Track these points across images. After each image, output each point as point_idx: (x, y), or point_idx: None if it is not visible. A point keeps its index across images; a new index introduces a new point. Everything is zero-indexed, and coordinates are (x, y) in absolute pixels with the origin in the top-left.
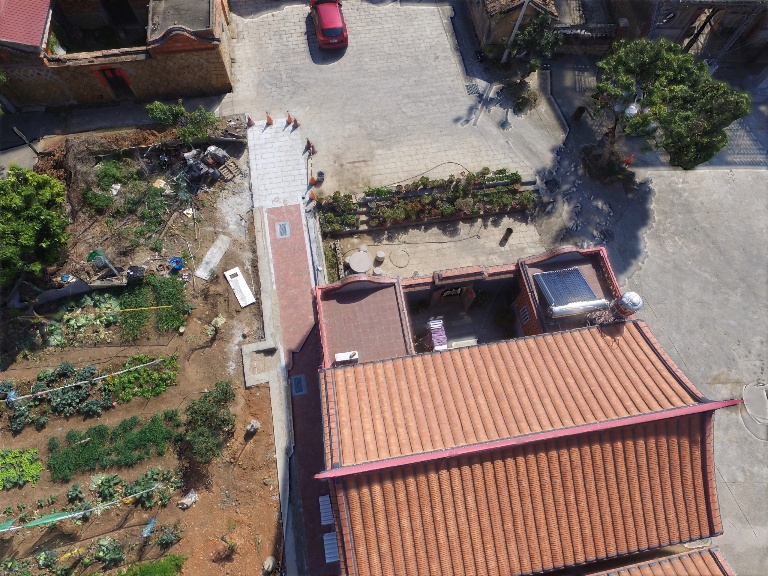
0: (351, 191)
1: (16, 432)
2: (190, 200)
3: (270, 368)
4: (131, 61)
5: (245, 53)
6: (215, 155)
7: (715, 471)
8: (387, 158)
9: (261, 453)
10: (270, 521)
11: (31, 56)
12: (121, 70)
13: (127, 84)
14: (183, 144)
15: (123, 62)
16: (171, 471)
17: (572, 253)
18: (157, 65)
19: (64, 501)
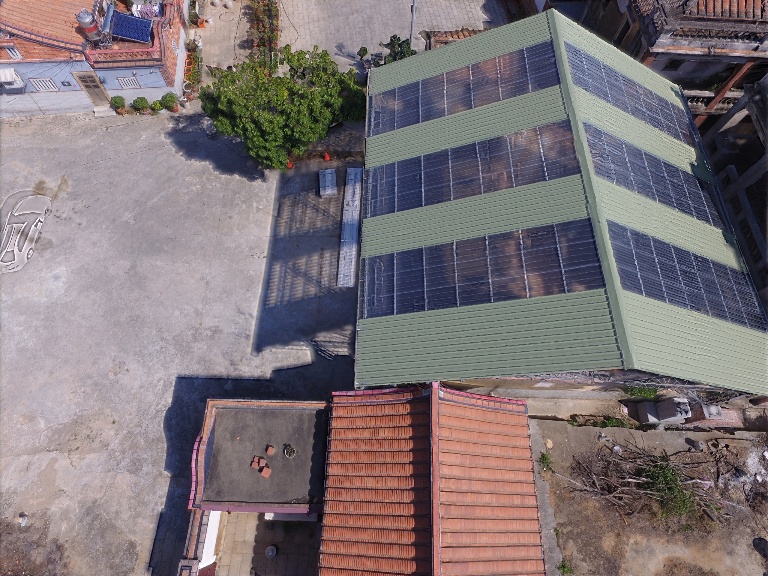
0: None
1: None
2: None
3: None
4: None
5: None
6: None
7: (3, 162)
8: (307, 3)
9: None
10: None
11: None
12: None
13: None
14: None
15: None
16: None
17: None
18: None
19: None
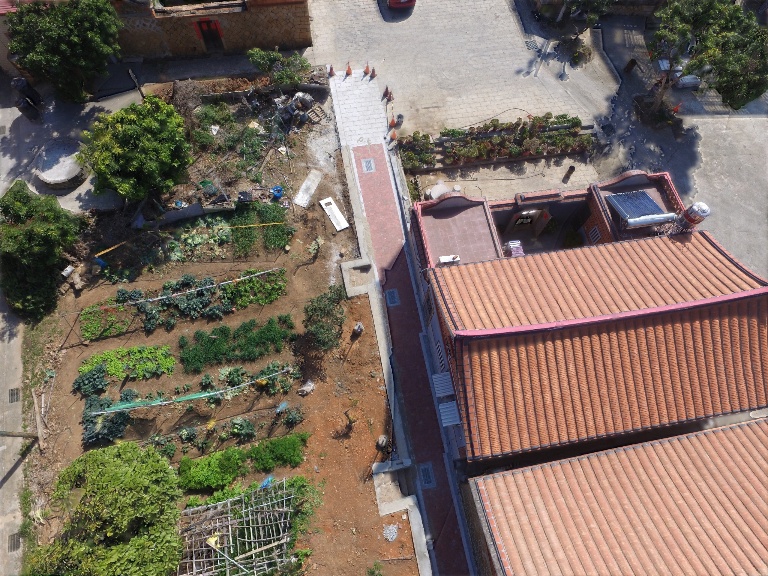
0: (428, 133)
1: (149, 332)
2: (284, 139)
3: (366, 283)
4: (228, 13)
5: (321, 12)
6: (304, 99)
7: None
8: (458, 104)
9: (366, 351)
10: (379, 407)
11: (142, 6)
12: (217, 22)
13: (220, 37)
14: (274, 90)
15: (221, 14)
16: (289, 365)
17: (641, 176)
18: (250, 18)
19: (197, 389)
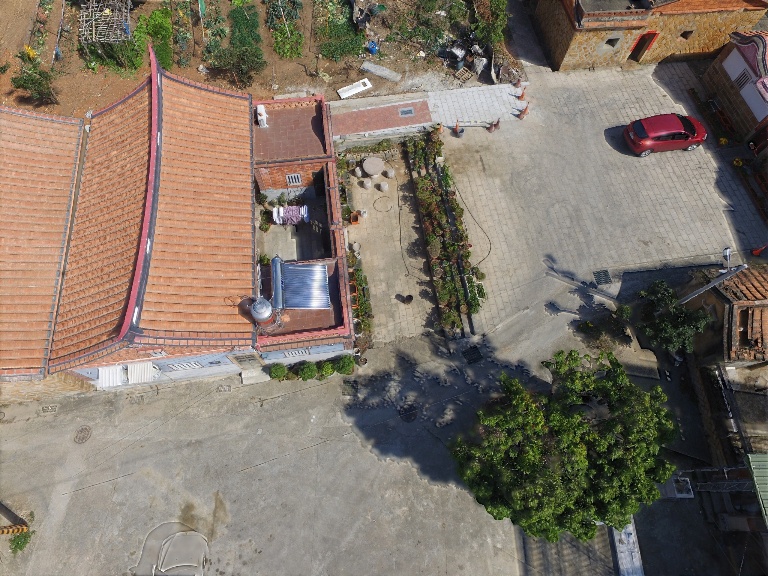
0: (448, 159)
1: None
2: None
3: None
4: None
5: (604, 77)
6: None
7: (131, 470)
8: (490, 188)
9: None
10: None
11: None
12: None
13: None
14: None
15: None
16: None
17: None
18: (554, 4)
19: None
